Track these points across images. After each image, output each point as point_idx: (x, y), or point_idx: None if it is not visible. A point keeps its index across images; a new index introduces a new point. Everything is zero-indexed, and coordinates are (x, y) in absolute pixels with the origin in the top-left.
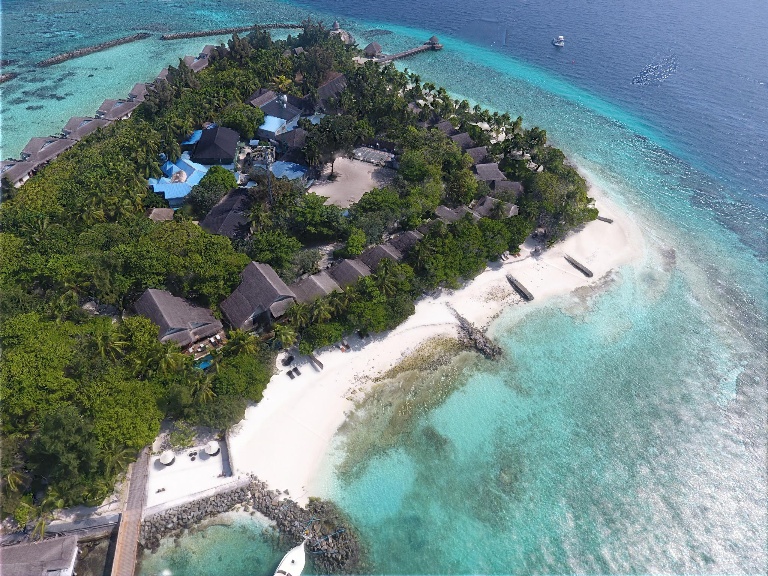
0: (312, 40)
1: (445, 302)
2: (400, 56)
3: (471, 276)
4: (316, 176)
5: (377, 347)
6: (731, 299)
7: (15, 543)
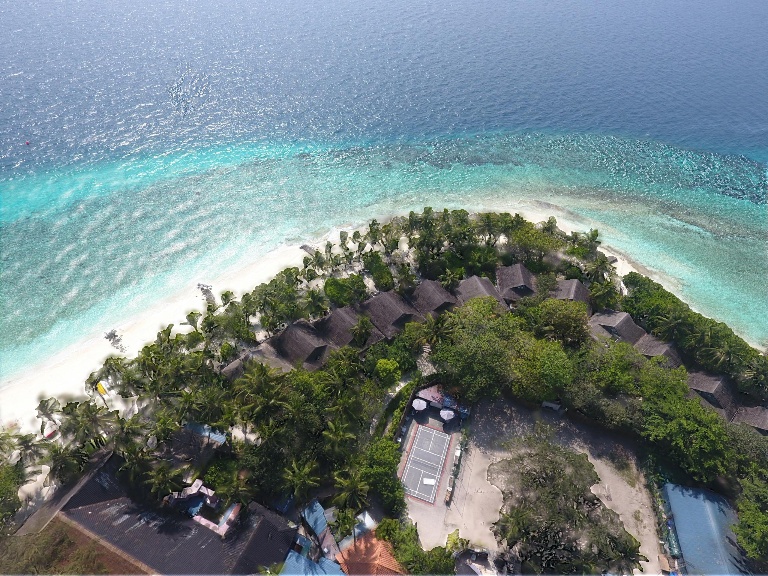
0: None
1: None
2: None
3: None
4: None
5: None
6: (588, 194)
7: None
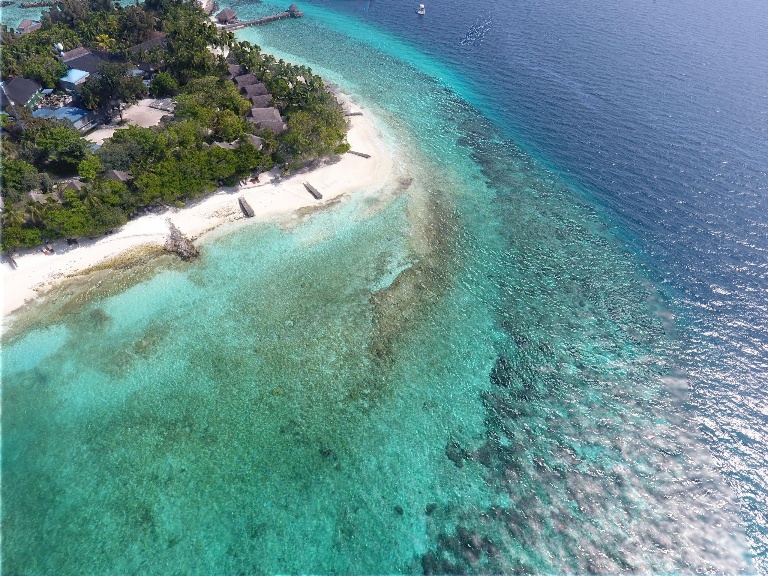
0: (158, 5)
1: (166, 218)
2: (254, 22)
3: (192, 195)
4: (105, 121)
5: (82, 252)
6: (439, 215)
7: None
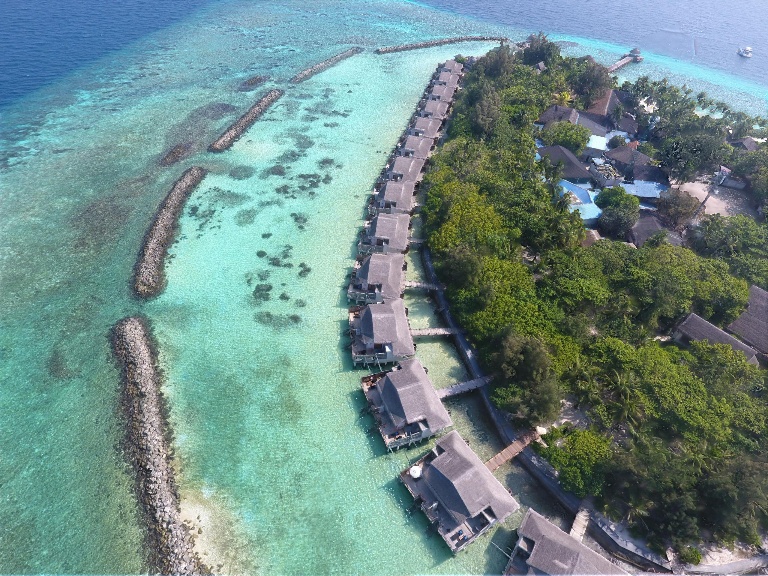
0: (546, 54)
1: None
2: (614, 69)
3: None
4: None
5: None
6: None
7: (766, 565)
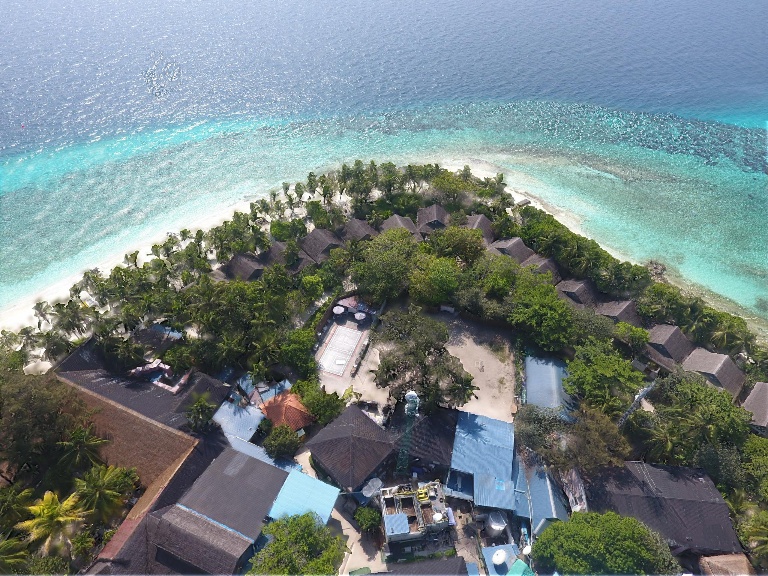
0: None
1: None
2: None
3: None
4: None
5: None
6: (517, 151)
7: None
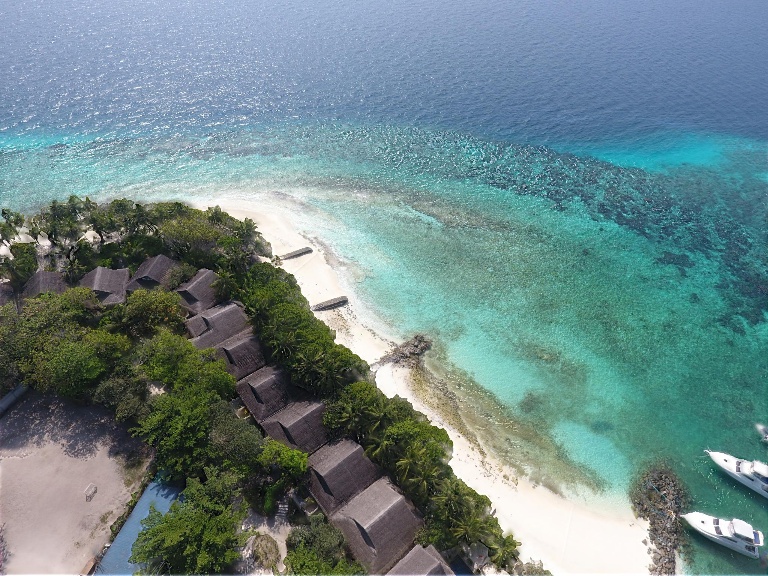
0: None
1: None
2: None
3: None
4: None
5: None
6: (338, 185)
7: None
